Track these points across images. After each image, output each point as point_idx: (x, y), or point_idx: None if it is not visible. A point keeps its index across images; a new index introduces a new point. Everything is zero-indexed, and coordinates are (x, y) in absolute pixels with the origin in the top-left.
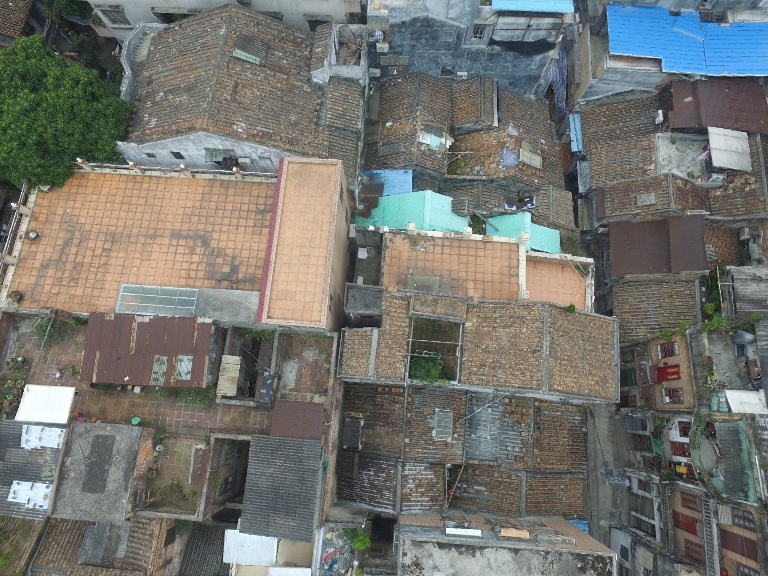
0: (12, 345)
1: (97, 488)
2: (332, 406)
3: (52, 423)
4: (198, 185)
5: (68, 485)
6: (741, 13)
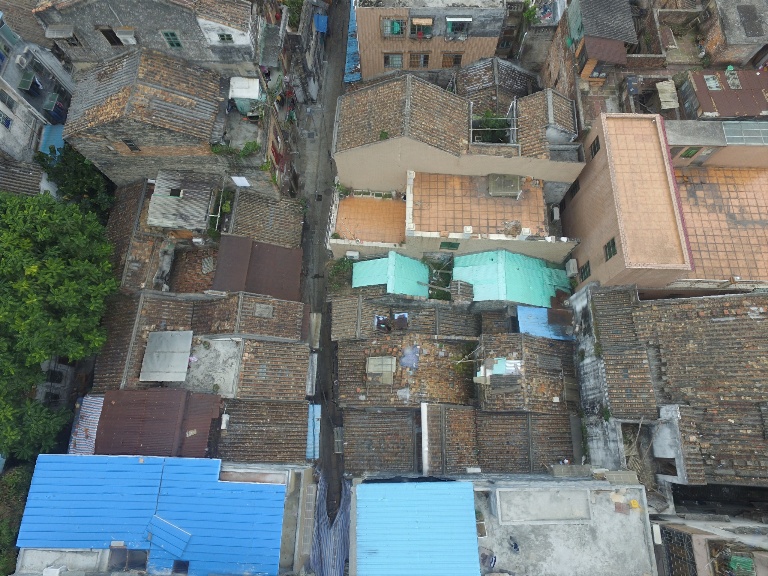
0: None
1: (744, 7)
2: None
3: None
4: (767, 278)
5: (767, 7)
6: (89, 567)
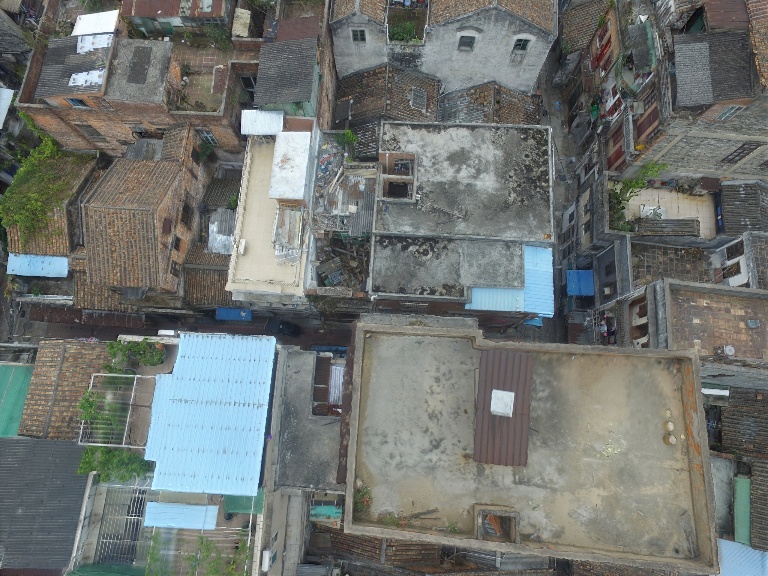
0: (61, 16)
1: (139, 80)
2: None
3: (102, 32)
4: None
5: (116, 78)
6: None
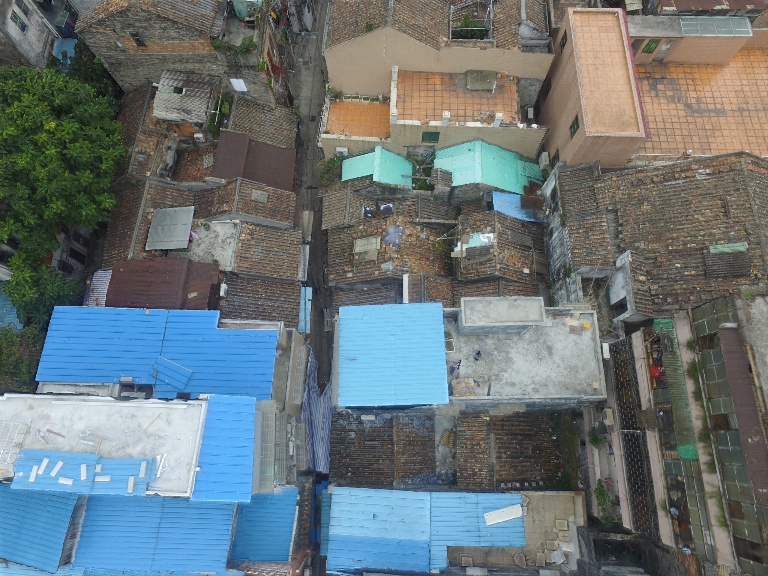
0: None
1: None
2: None
3: None
4: None
5: None
6: None
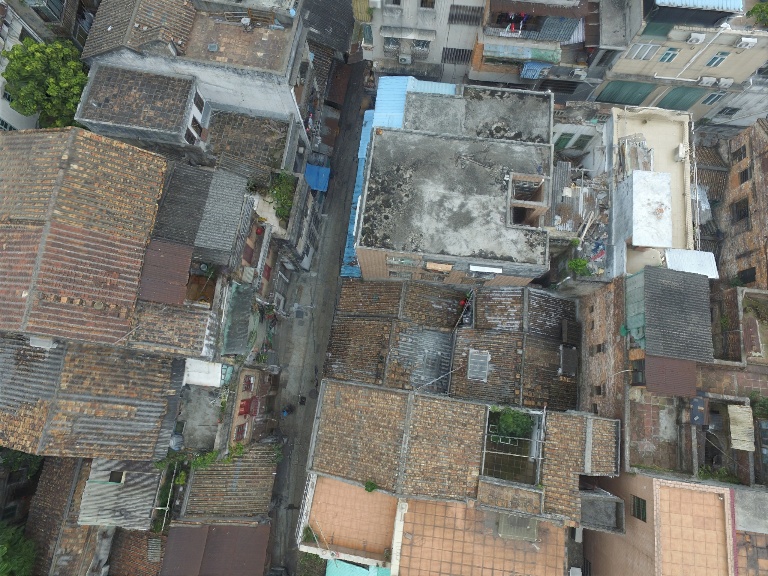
0: None
1: None
2: (619, 389)
3: None
4: None
5: None
6: None
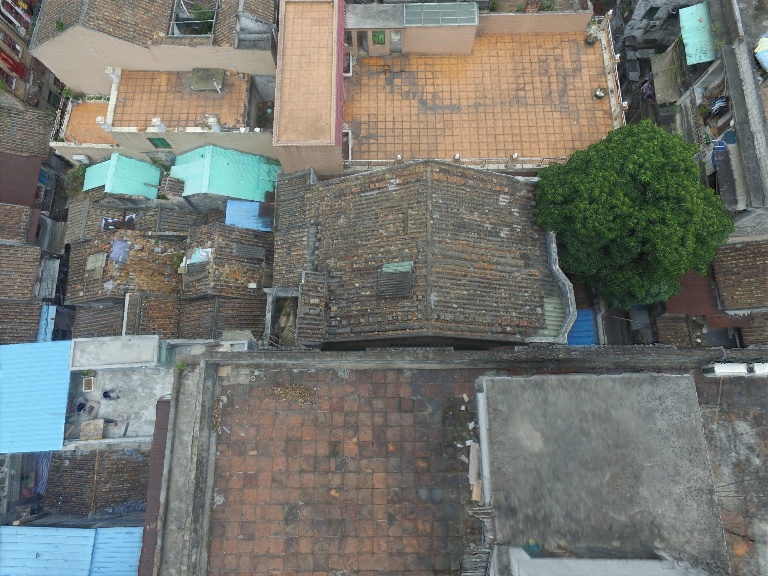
0: None
1: None
2: None
3: None
4: None
5: None
6: None
